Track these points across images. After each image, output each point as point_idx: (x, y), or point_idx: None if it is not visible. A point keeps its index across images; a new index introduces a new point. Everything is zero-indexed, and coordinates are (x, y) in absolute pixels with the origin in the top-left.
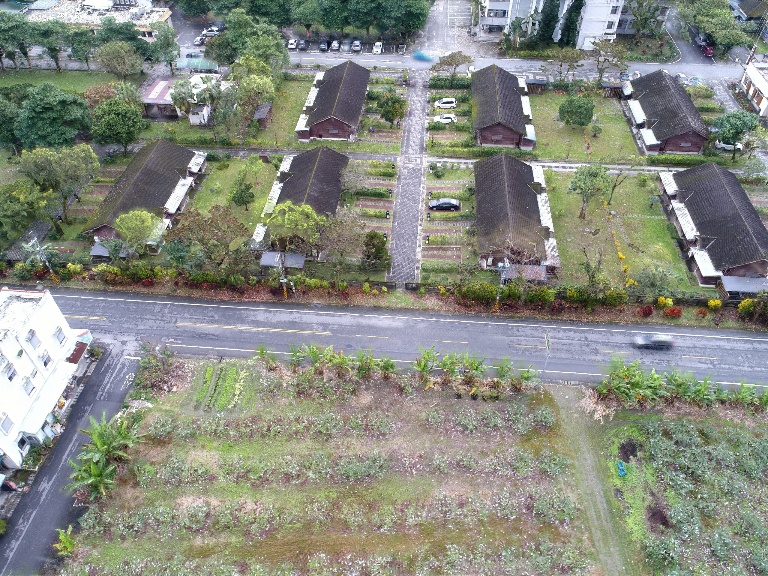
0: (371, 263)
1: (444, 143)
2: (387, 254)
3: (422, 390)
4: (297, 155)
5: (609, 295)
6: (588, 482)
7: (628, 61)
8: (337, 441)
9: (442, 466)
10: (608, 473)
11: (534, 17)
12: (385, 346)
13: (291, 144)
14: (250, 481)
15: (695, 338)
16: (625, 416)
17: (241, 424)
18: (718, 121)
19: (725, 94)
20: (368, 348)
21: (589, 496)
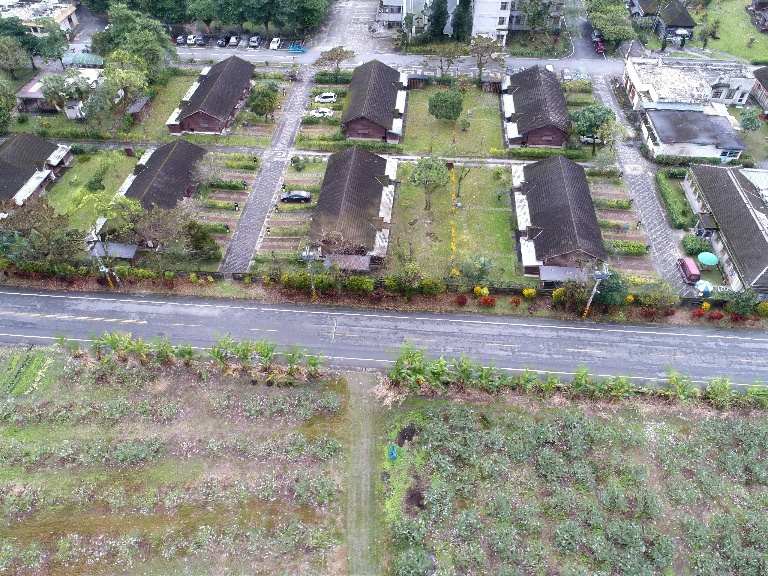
0: (193, 253)
1: (313, 137)
2: (212, 244)
3: (220, 377)
4: (158, 148)
5: (424, 284)
6: (358, 465)
7: (519, 57)
8: (122, 426)
9: (214, 450)
10: (381, 457)
11: (425, 13)
12: (196, 334)
13: (163, 138)
14: (25, 465)
15: (503, 326)
16: (414, 402)
17: (27, 409)
18: (575, 115)
19: (606, 89)
20: (179, 336)
21: (355, 479)
